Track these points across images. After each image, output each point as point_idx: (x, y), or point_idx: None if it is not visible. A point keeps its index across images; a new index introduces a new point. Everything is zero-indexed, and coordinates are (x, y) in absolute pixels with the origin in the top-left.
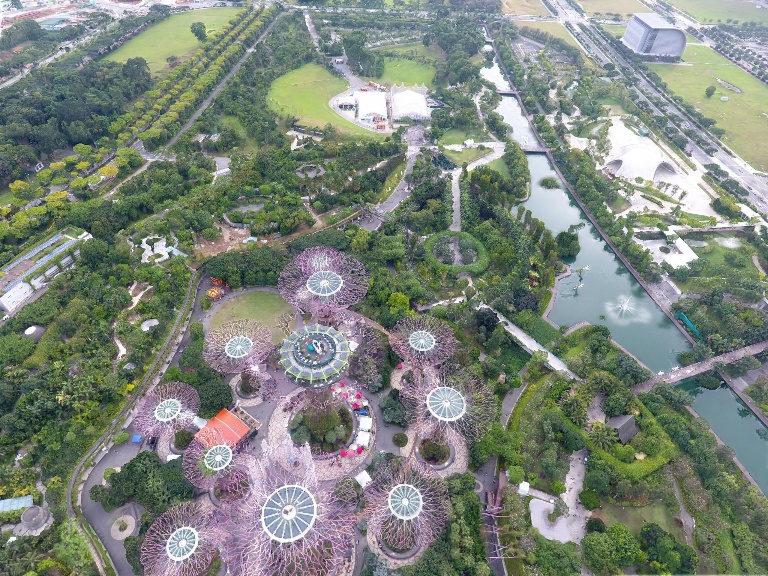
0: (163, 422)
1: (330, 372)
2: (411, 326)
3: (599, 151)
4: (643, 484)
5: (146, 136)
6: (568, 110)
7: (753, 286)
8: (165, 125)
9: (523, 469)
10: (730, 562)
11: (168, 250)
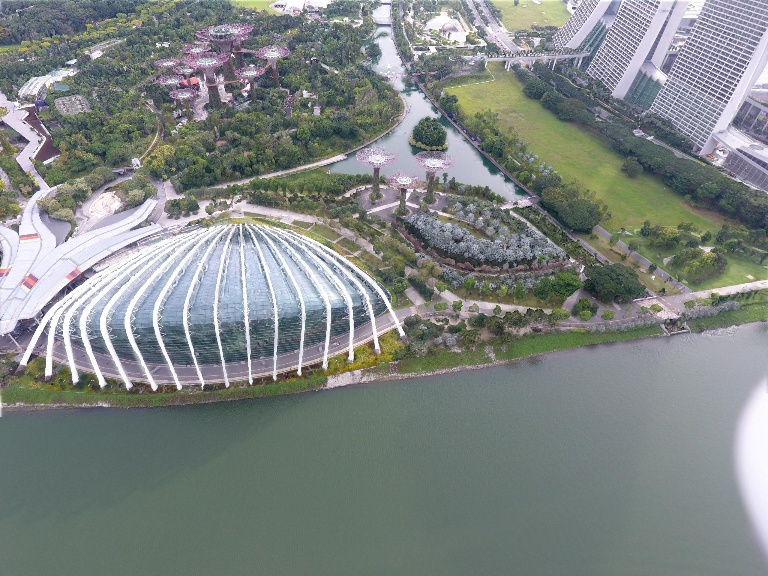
0: (166, 65)
1: (225, 33)
2: (271, 48)
3: (418, 21)
4: (346, 84)
5: (157, 11)
6: (415, 8)
7: (447, 54)
8: (168, 8)
9: (306, 88)
10: (372, 105)
11: (169, 44)
